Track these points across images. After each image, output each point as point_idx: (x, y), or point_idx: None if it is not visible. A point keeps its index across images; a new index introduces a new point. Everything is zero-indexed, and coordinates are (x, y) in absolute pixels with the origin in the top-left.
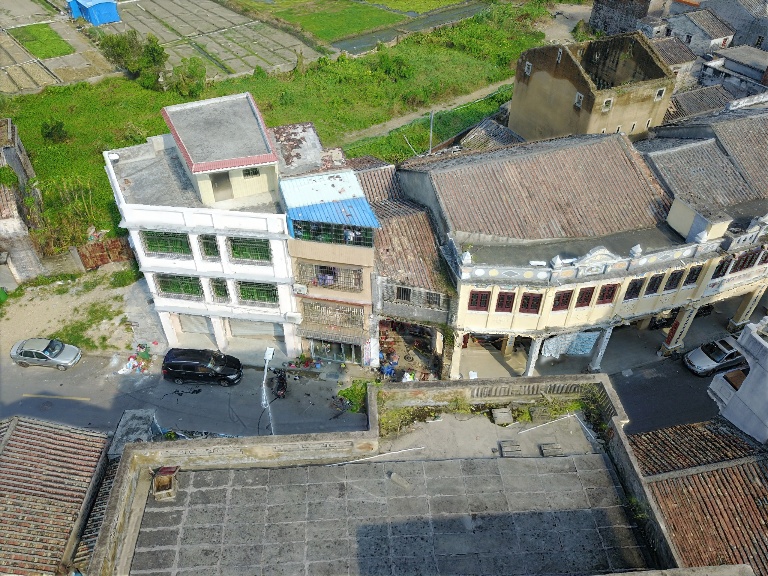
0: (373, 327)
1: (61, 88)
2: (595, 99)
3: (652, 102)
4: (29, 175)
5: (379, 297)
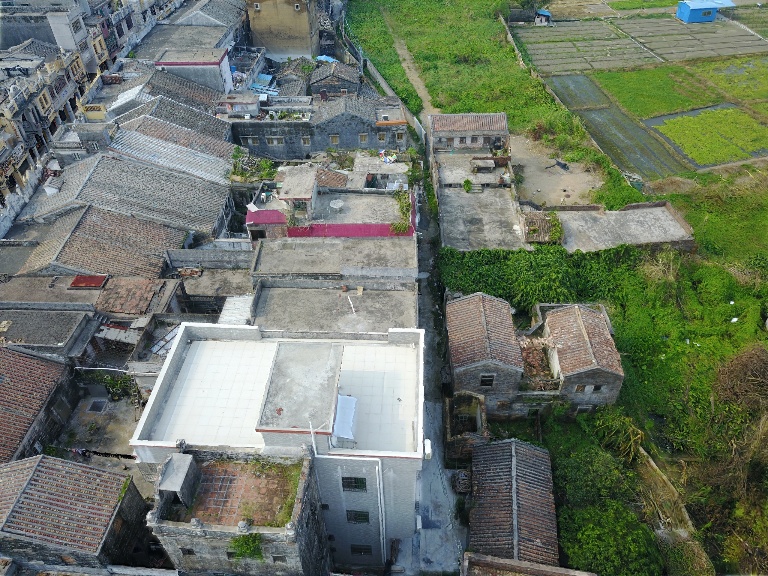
0: None
1: None
2: None
3: None
4: None
5: None
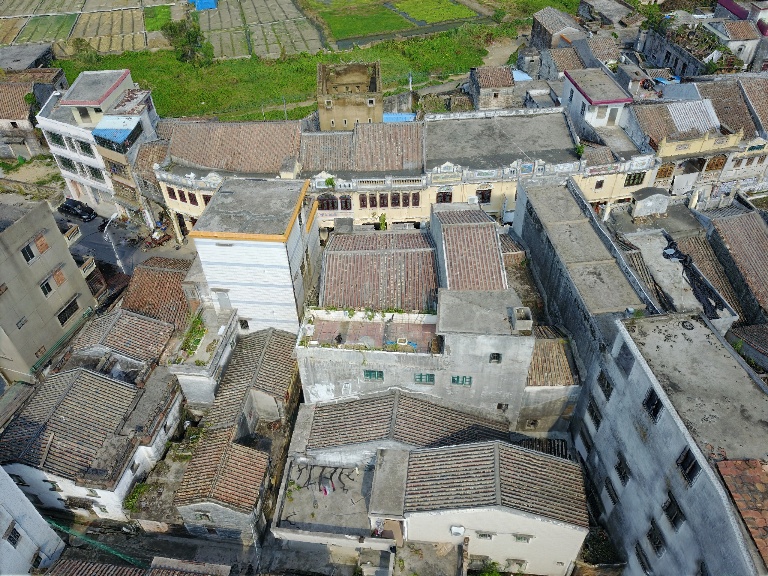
0: (143, 203)
1: (133, 53)
2: (317, 99)
3: (367, 107)
4: None
5: (138, 184)
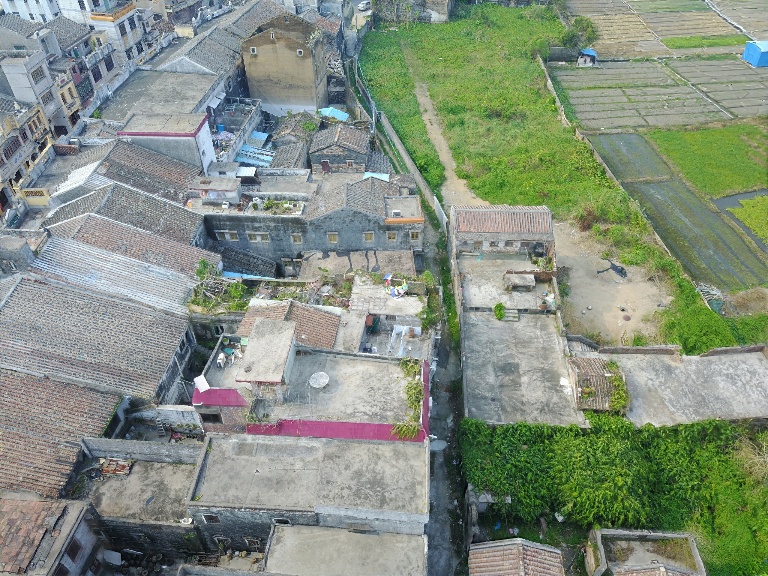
0: None
1: None
2: None
3: None
4: (429, 6)
5: None
